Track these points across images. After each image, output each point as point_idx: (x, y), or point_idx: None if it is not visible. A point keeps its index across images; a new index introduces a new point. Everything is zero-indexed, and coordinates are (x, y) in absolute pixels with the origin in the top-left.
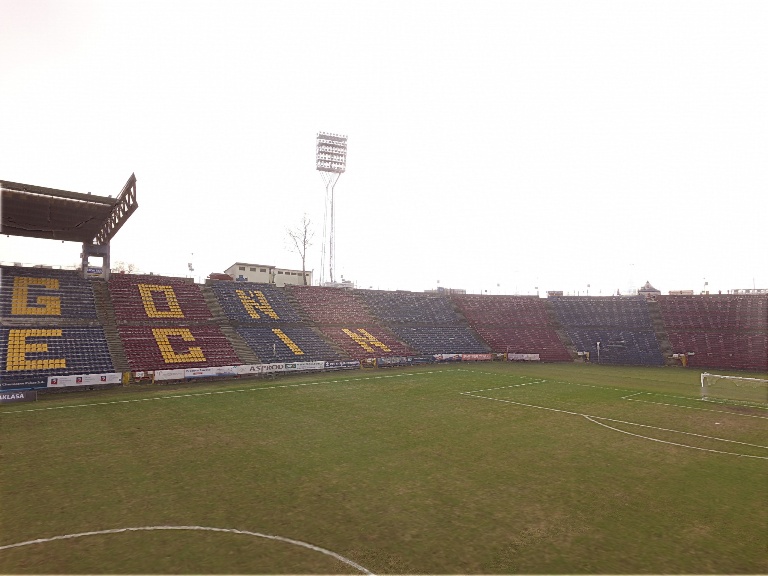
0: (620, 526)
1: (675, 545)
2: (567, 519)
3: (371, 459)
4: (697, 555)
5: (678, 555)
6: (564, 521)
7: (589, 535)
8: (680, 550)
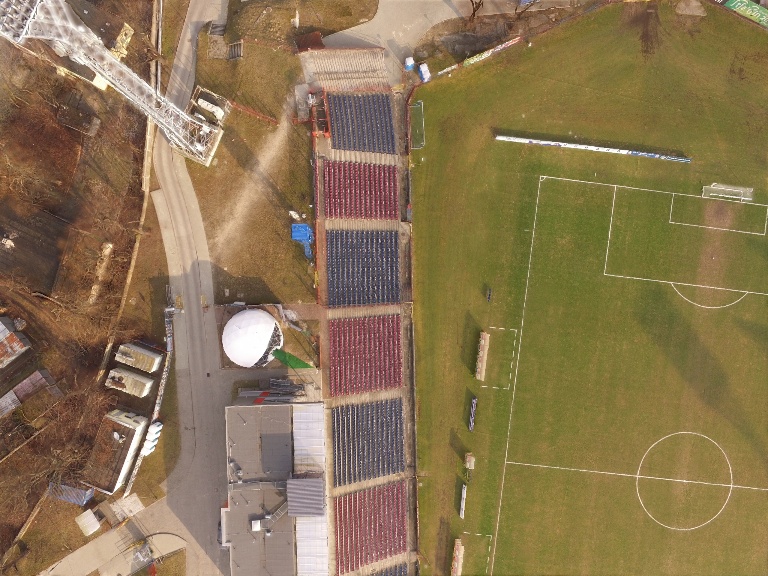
0: (659, 575)
1: (650, 575)
2: (667, 571)
3: (720, 569)
4: (646, 574)
5: (649, 571)
6: (667, 570)
7: (662, 568)
8: (649, 574)
